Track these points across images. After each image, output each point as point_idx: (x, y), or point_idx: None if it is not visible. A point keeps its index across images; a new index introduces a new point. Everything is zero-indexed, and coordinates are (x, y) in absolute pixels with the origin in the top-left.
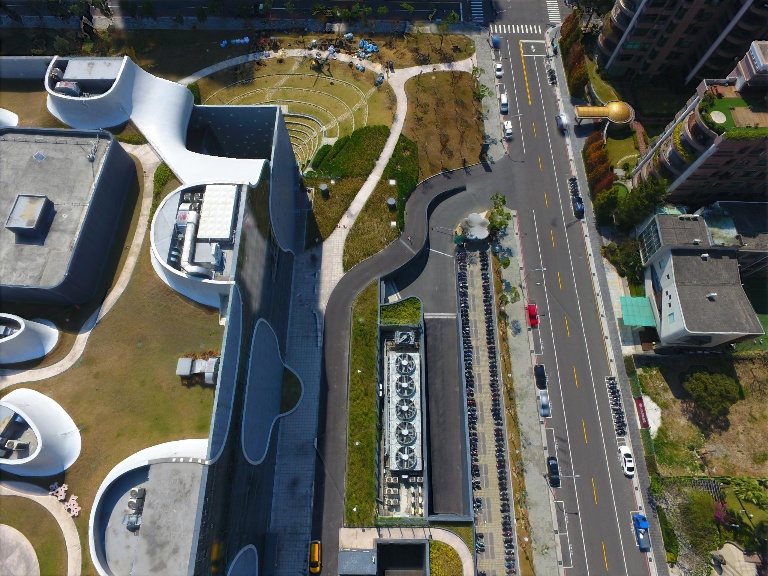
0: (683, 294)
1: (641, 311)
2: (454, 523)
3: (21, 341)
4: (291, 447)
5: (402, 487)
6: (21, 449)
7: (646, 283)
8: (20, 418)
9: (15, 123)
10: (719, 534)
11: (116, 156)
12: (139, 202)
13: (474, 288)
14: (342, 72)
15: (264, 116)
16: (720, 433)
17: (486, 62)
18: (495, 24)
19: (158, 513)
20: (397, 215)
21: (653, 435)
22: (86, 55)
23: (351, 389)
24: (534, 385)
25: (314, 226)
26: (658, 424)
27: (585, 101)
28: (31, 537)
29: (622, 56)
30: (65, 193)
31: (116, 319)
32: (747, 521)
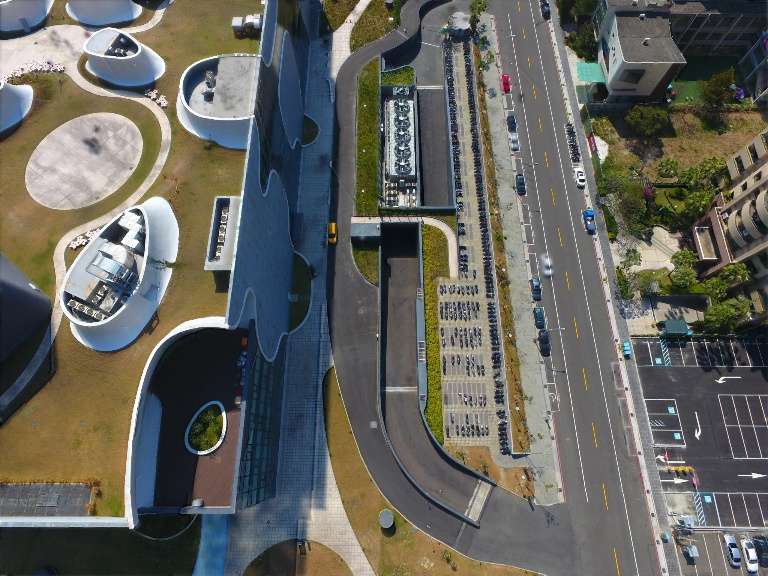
0: (624, 42)
1: (593, 72)
2: (441, 213)
3: (118, 1)
4: (311, 167)
5: (400, 194)
6: None
7: (599, 55)
8: (123, 40)
9: None
10: (650, 219)
11: None
12: None
13: (458, 68)
14: None
15: None
16: (655, 159)
17: None
18: None
19: (227, 82)
20: (394, 13)
21: (601, 161)
22: None
23: (358, 128)
24: (506, 130)
25: (325, 21)
26: (606, 154)
27: None
28: (134, 120)
29: None
30: None
31: (183, 3)
32: (672, 211)
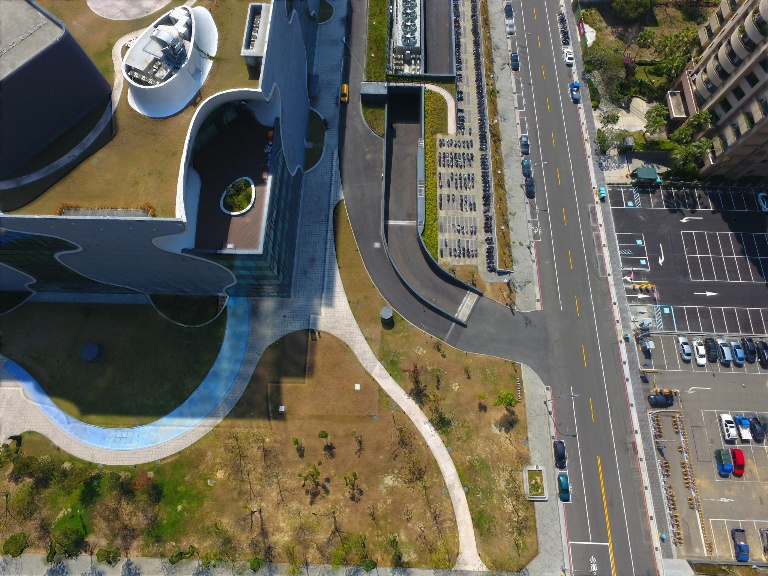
0: None
1: None
2: (442, 81)
3: None
4: (326, 41)
5: (406, 66)
6: None
7: None
8: None
9: None
10: (630, 91)
11: None
12: None
13: None
14: None
15: None
16: None
17: None
18: None
19: None
20: None
21: (589, 45)
22: None
23: (369, 10)
24: (504, 18)
25: None
26: (593, 39)
27: None
28: None
29: None
30: None
31: None
32: None
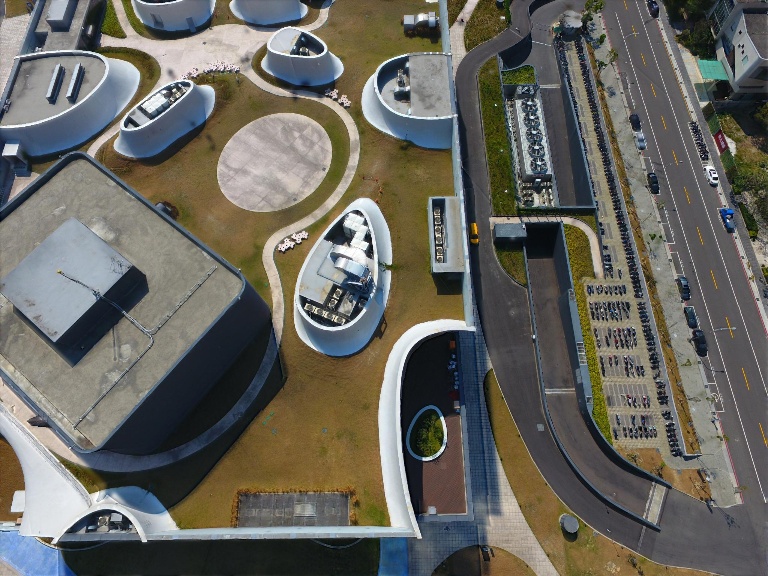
0: (755, 39)
1: (716, 70)
2: (580, 213)
3: None
4: None
5: (534, 193)
6: None
7: (718, 52)
8: (304, 39)
9: None
10: None
11: None
12: None
13: (573, 66)
14: None
15: None
16: None
17: None
18: None
19: (421, 81)
20: (505, 12)
21: None
22: None
23: (485, 128)
24: (631, 129)
25: None
26: (734, 152)
27: None
28: (318, 120)
29: None
30: None
31: (346, 1)
32: None
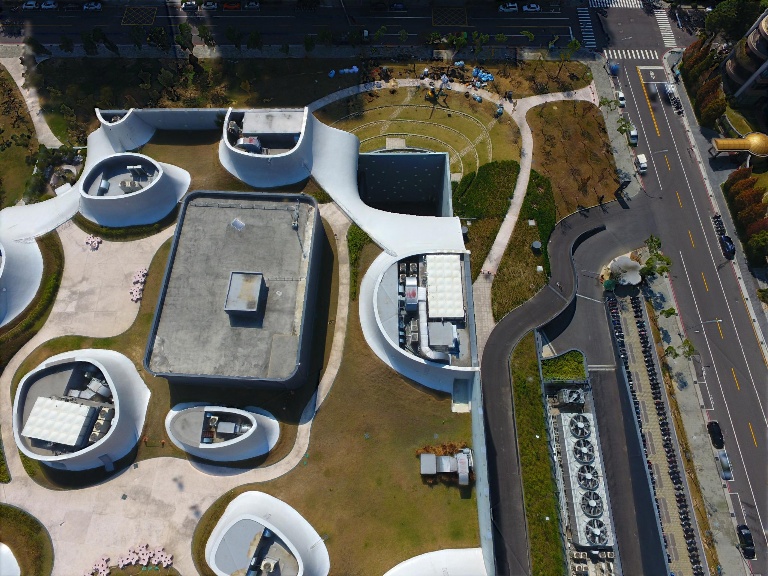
0: None
1: None
2: None
3: (251, 439)
4: None
5: (589, 562)
6: (274, 569)
7: None
8: (268, 532)
9: (188, 181)
10: None
11: (318, 222)
12: (335, 269)
13: (630, 337)
14: (459, 103)
15: (427, 163)
16: None
17: (606, 90)
18: (609, 49)
19: None
20: (543, 259)
21: None
22: (198, 89)
23: (521, 453)
24: (710, 444)
25: None
26: None
27: (716, 132)
28: None
29: (758, 85)
30: (274, 266)
31: (336, 406)
32: None
